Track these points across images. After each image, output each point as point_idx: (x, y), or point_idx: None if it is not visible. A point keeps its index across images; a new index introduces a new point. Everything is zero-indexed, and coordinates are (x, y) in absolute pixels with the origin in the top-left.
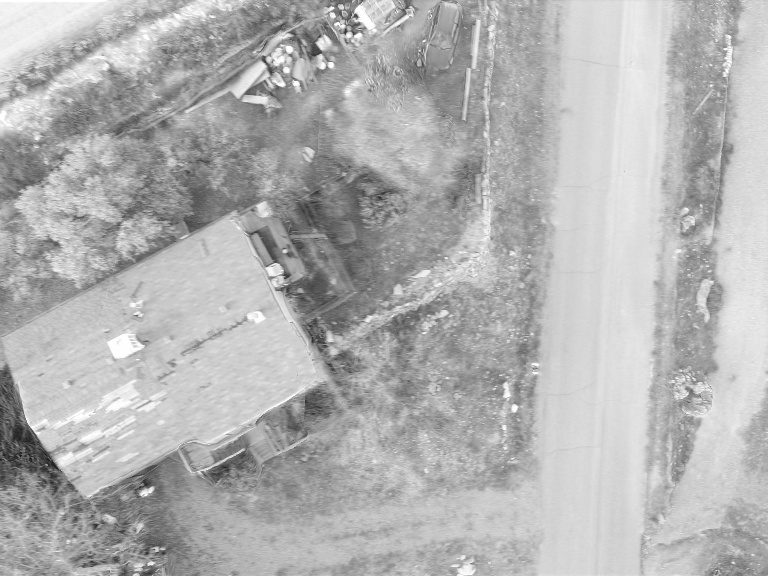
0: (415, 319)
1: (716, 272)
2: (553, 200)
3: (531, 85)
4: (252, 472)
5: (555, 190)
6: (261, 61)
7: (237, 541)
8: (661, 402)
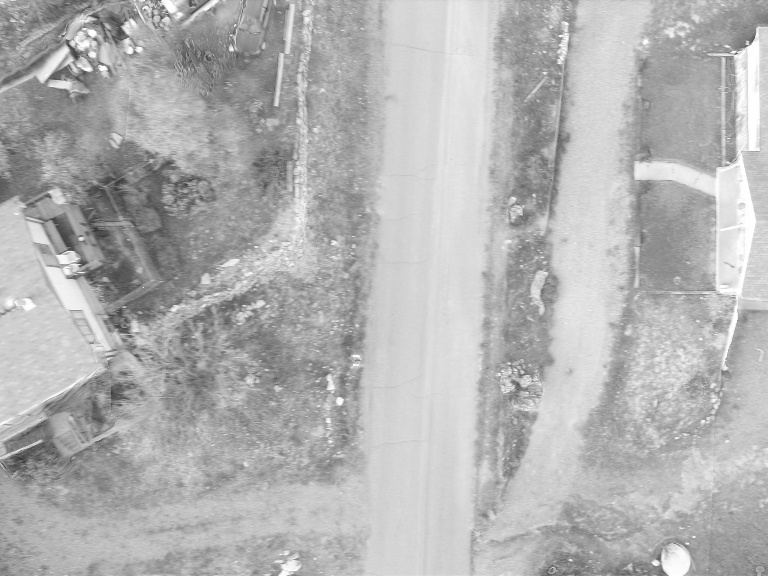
0: (230, 309)
1: (551, 263)
2: (378, 189)
3: (354, 71)
4: (51, 464)
5: (380, 179)
6: (65, 45)
7: (47, 535)
8: (490, 395)
